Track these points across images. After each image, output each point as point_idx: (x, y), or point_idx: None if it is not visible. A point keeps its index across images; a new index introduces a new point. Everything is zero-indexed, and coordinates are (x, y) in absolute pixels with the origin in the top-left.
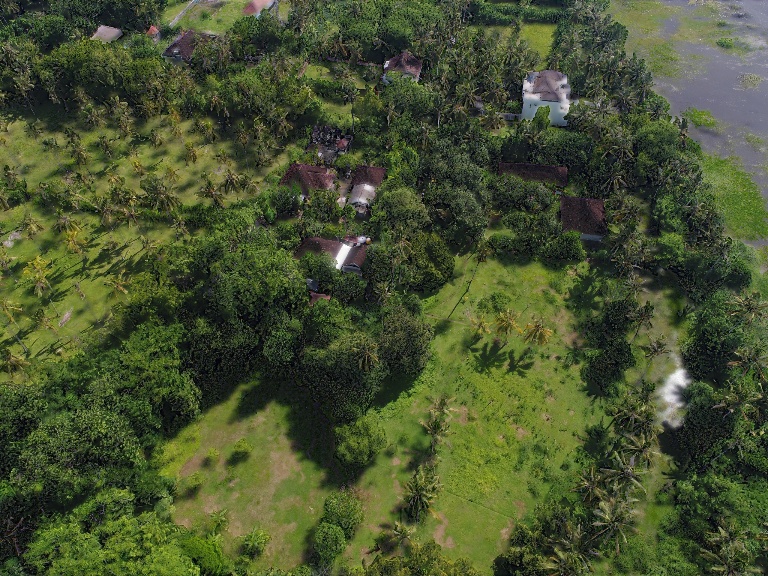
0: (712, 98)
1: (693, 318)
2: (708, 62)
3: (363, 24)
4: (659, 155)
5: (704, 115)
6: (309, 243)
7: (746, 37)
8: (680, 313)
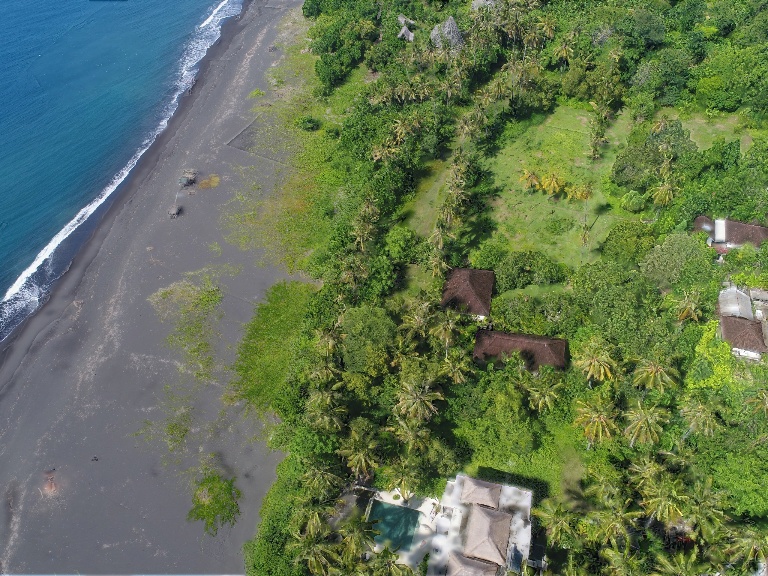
0: (154, 561)
1: (396, 213)
2: None
3: None
4: None
5: (204, 505)
6: (761, 230)
7: None
8: (404, 217)
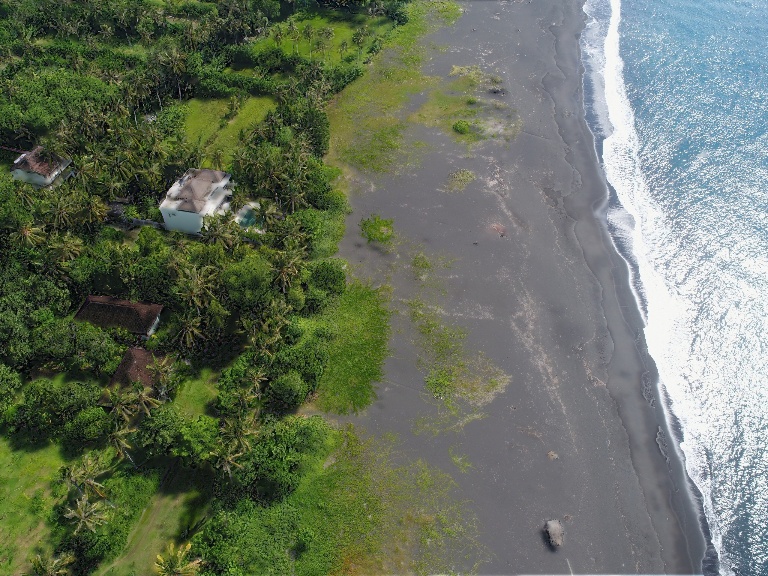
0: (406, 202)
1: None
2: (428, 152)
3: (10, 107)
4: (243, 301)
5: (384, 226)
6: None
7: (488, 120)
8: (184, 533)
